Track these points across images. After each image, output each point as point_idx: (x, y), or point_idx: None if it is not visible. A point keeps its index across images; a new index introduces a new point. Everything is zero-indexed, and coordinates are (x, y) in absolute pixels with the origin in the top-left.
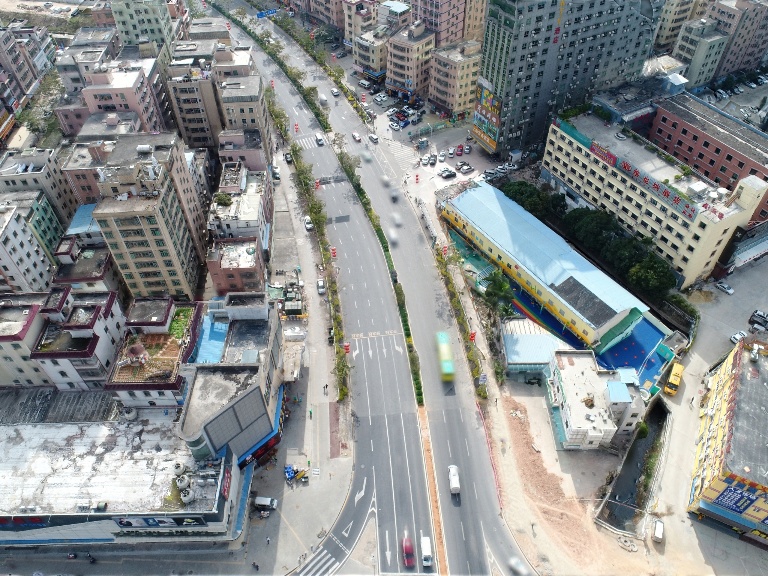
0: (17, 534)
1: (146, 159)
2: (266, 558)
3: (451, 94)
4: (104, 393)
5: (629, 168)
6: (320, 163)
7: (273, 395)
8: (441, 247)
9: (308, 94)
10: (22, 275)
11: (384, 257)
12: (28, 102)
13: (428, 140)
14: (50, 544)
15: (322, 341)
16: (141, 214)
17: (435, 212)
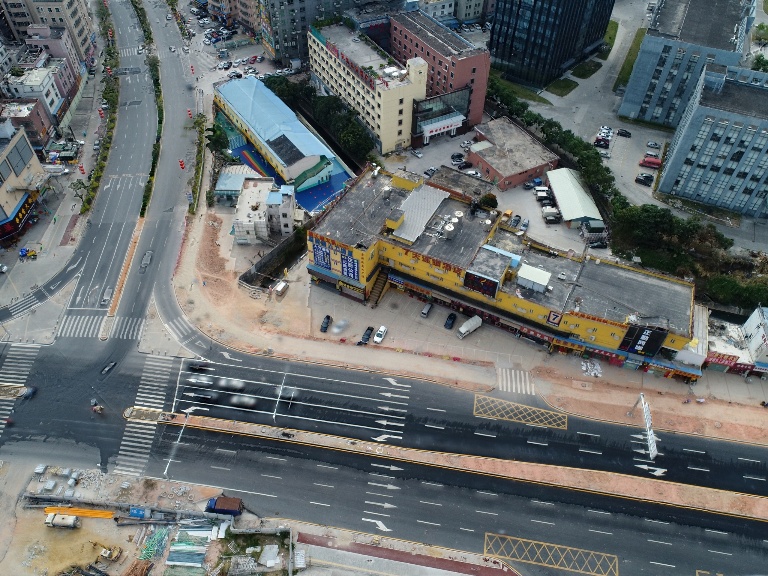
0: None
1: None
2: None
3: (250, 14)
4: None
5: (344, 57)
6: (133, 65)
7: (8, 190)
8: None
9: None
10: None
11: (157, 128)
12: None
13: (229, 51)
14: None
15: (83, 178)
16: None
17: (212, 100)
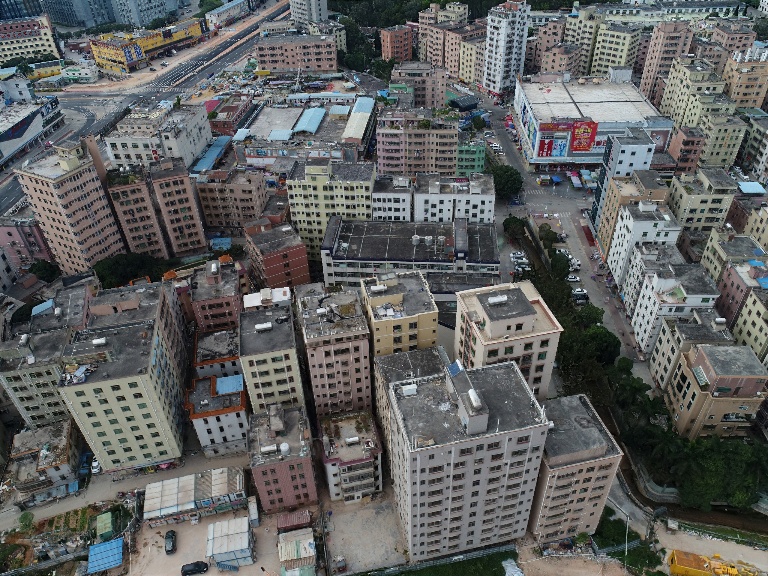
0: (22, 139)
1: None
2: None
3: None
4: None
5: (4, 36)
6: None
7: None
8: None
9: None
10: None
11: None
12: None
13: None
14: None
15: None
16: None
17: None
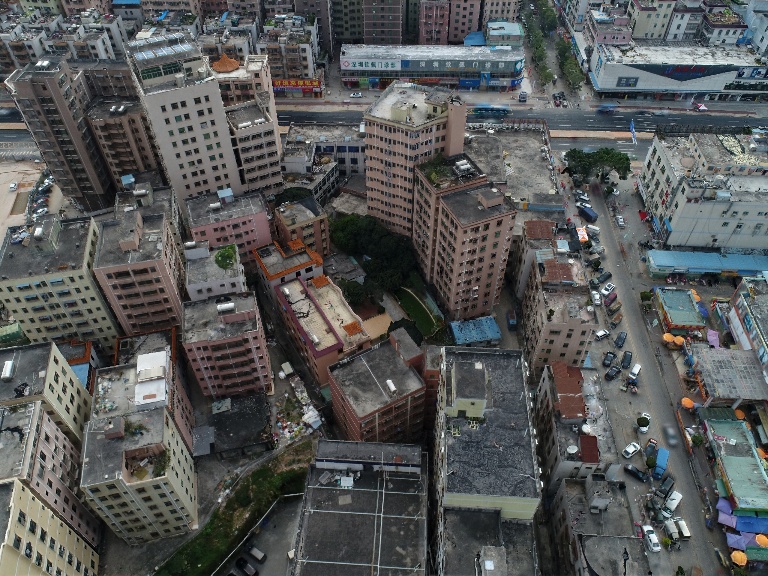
0: (680, 84)
1: None
2: None
3: None
4: (688, 42)
5: None
6: None
7: None
8: None
9: None
10: (610, 2)
11: None
12: None
13: None
14: (692, 91)
15: None
16: None
17: None
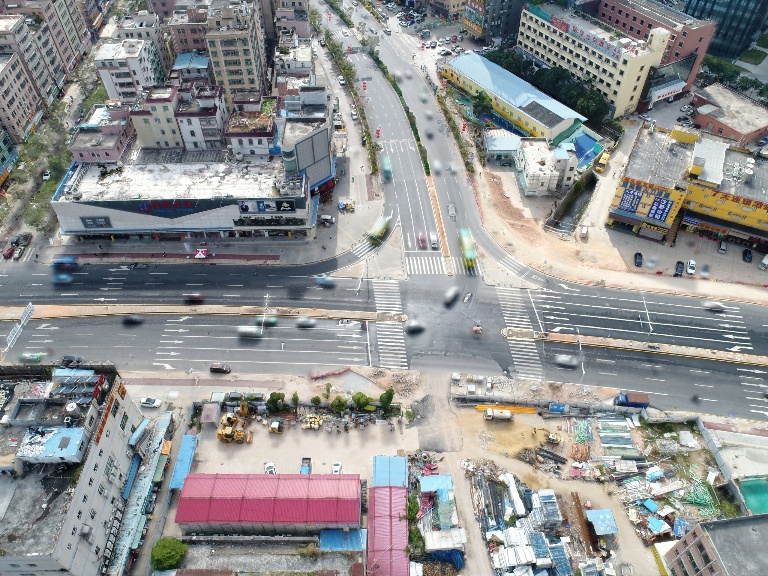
0: (172, 221)
1: (237, 7)
2: (330, 245)
3: None
4: (217, 152)
5: (577, 31)
6: None
7: None
8: (441, 94)
9: (334, 2)
10: None
11: (399, 100)
12: (110, 7)
13: (430, 32)
14: (192, 230)
15: (357, 144)
16: (238, 37)
17: (436, 75)
